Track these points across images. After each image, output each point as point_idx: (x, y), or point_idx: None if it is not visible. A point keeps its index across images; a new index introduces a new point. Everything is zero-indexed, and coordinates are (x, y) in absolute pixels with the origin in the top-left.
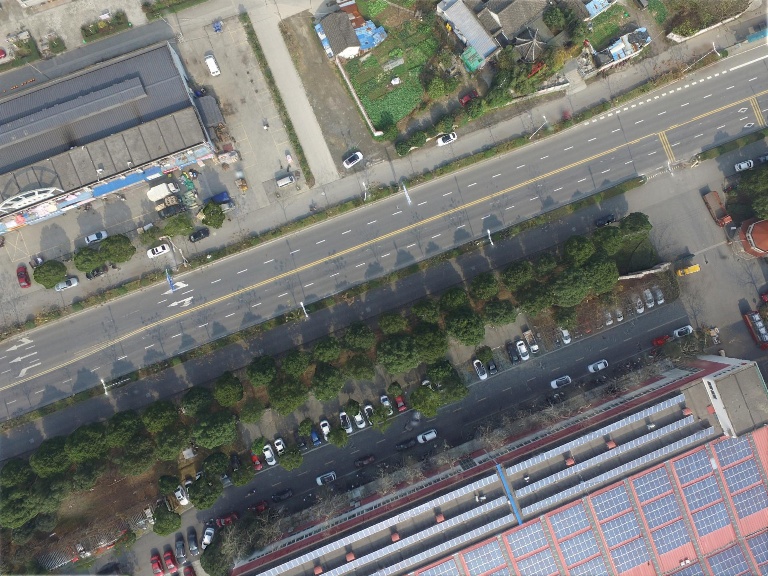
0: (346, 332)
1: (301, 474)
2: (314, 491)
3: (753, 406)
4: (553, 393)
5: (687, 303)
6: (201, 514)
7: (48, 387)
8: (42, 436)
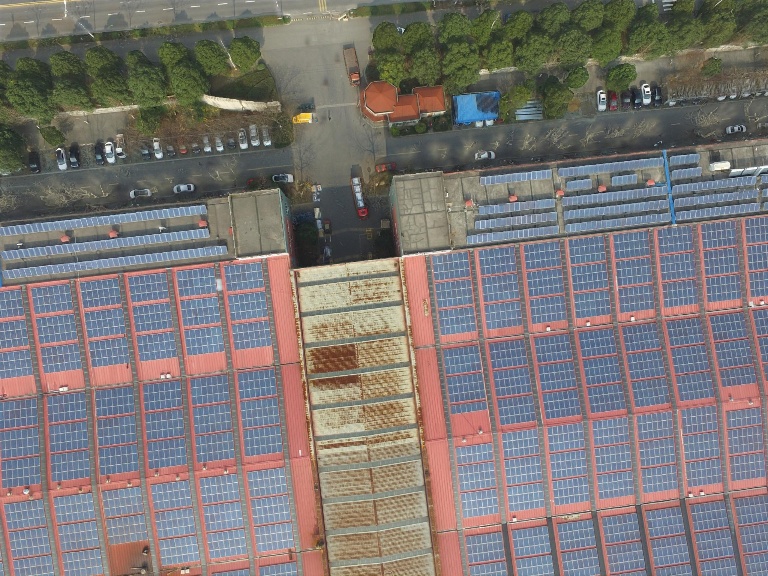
0: None
1: None
2: None
3: (266, 233)
4: (131, 203)
5: (297, 153)
6: None
7: None
8: None
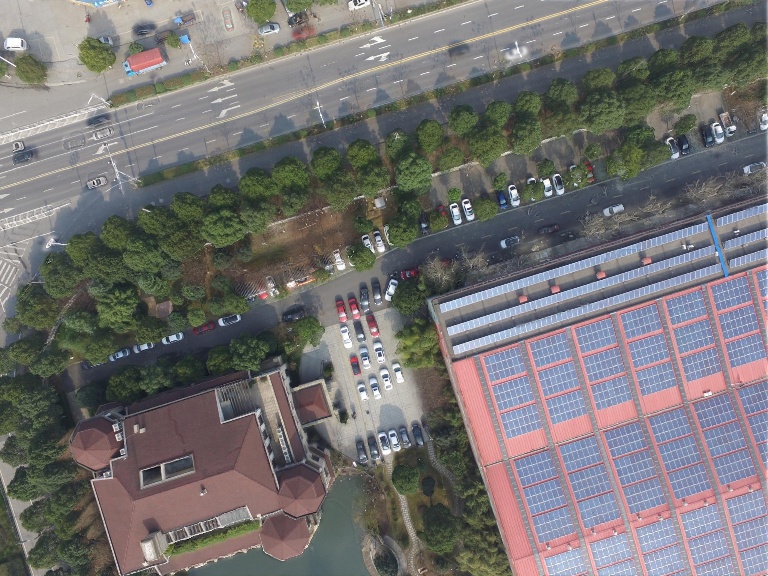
0: (551, 85)
1: (485, 237)
2: (497, 255)
3: None
4: None
5: None
6: (386, 266)
7: (246, 129)
8: (238, 177)
